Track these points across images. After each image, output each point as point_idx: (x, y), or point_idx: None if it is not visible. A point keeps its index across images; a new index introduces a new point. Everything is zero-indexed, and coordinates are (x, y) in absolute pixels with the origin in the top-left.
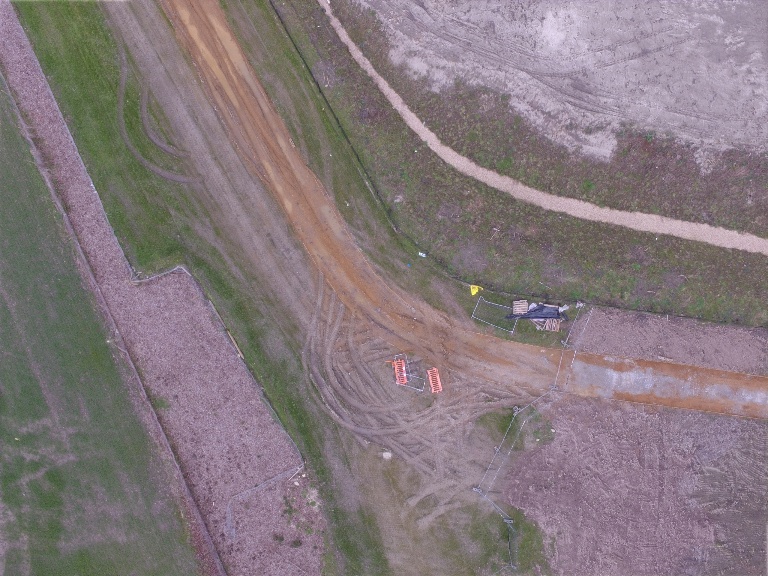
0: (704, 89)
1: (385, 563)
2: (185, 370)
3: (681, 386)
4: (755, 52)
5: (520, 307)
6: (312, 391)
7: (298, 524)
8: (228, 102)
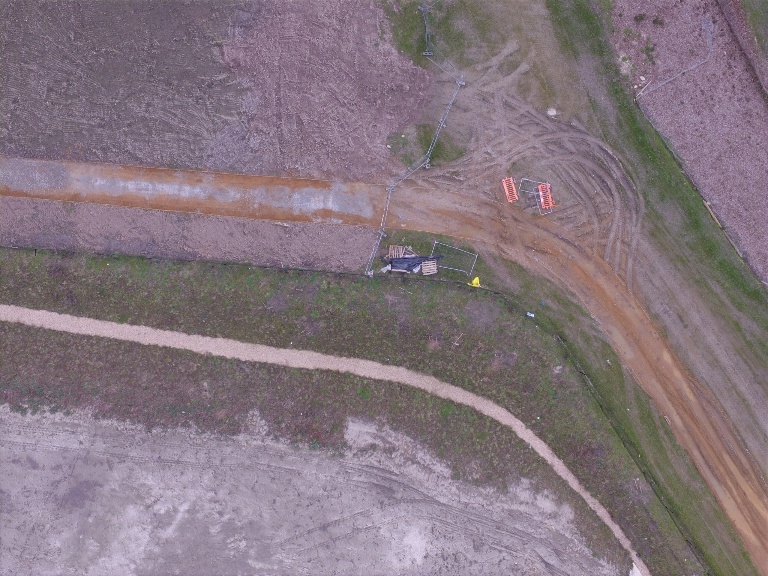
0: (264, 494)
1: (549, 4)
2: (763, 186)
3: (264, 198)
4: (216, 533)
5: (430, 268)
6: (632, 172)
7: (639, 38)
8: (735, 458)
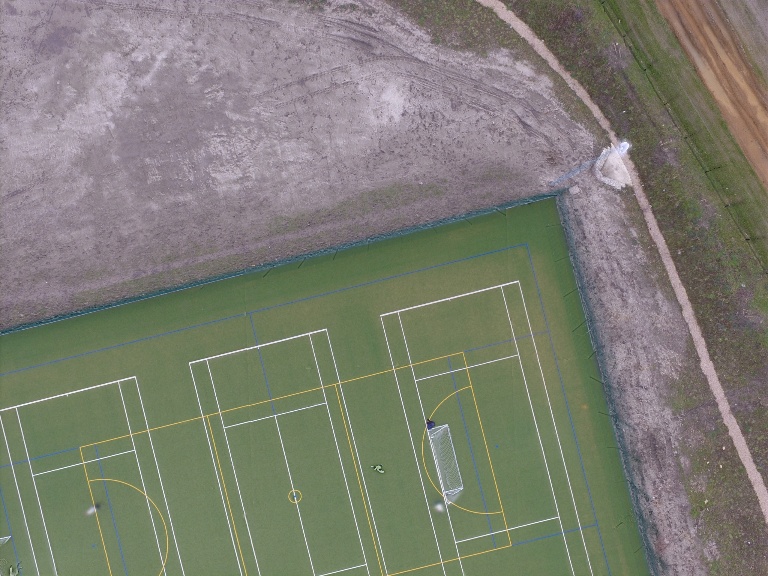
0: (242, 45)
1: None
2: None
3: None
4: (194, 83)
5: None
6: None
7: None
8: (715, 27)
